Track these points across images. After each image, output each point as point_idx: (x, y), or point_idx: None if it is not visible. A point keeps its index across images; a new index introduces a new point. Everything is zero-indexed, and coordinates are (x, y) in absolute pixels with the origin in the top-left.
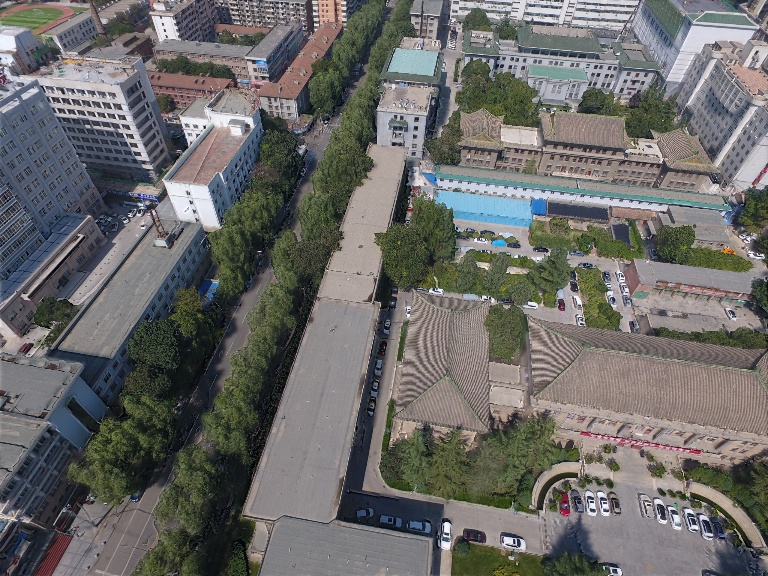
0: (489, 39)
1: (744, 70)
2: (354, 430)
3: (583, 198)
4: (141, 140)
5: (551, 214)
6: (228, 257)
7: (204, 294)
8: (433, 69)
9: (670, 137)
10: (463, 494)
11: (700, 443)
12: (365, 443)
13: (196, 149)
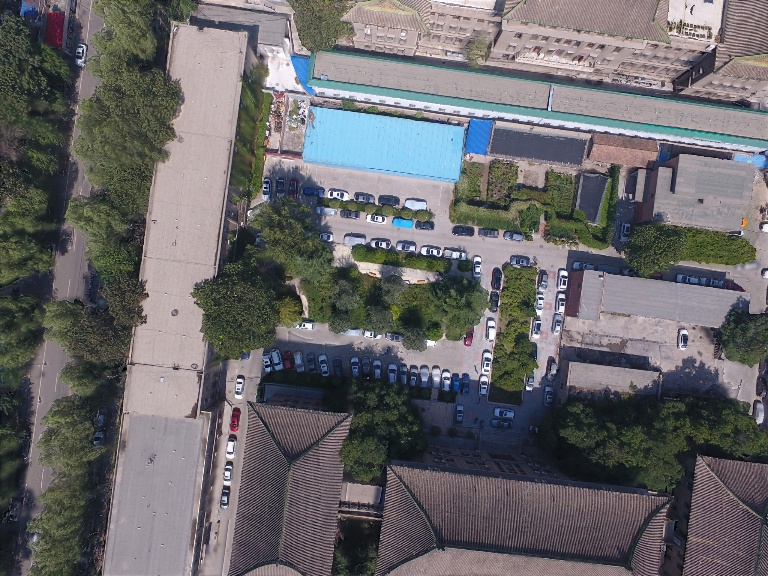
0: None
1: None
2: None
3: (553, 120)
4: None
5: (494, 154)
6: None
7: None
8: None
9: None
10: None
11: None
12: (221, 538)
13: None
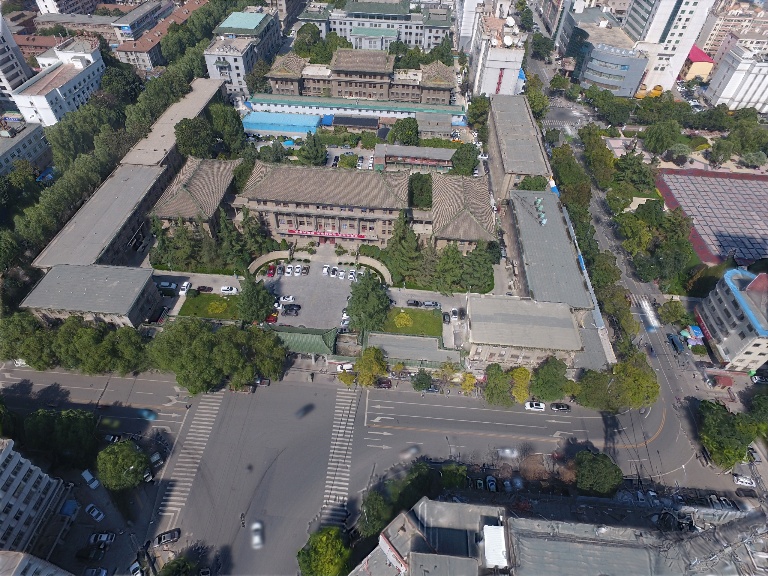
0: (324, 9)
1: (495, 19)
2: (121, 226)
3: (361, 112)
4: (4, 75)
5: (335, 124)
6: (59, 144)
7: (45, 176)
8: (256, 25)
9: (430, 67)
10: (203, 269)
11: (368, 233)
12: (146, 251)
13: (44, 77)
